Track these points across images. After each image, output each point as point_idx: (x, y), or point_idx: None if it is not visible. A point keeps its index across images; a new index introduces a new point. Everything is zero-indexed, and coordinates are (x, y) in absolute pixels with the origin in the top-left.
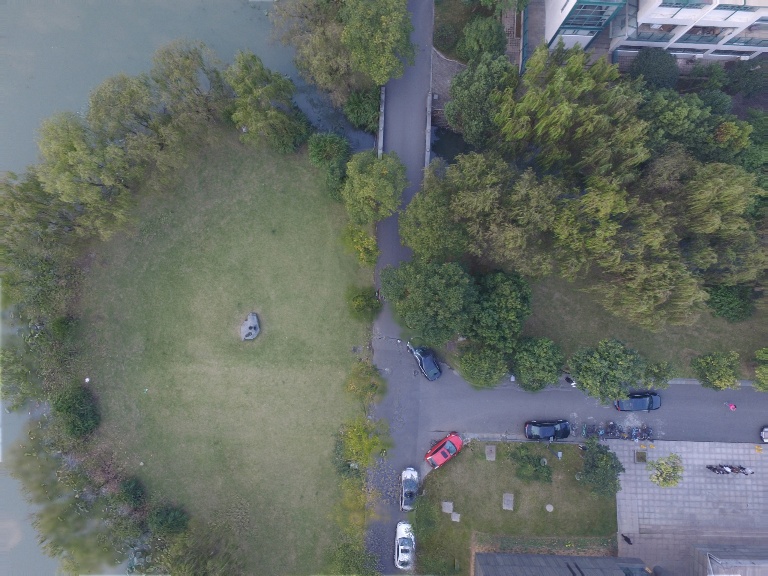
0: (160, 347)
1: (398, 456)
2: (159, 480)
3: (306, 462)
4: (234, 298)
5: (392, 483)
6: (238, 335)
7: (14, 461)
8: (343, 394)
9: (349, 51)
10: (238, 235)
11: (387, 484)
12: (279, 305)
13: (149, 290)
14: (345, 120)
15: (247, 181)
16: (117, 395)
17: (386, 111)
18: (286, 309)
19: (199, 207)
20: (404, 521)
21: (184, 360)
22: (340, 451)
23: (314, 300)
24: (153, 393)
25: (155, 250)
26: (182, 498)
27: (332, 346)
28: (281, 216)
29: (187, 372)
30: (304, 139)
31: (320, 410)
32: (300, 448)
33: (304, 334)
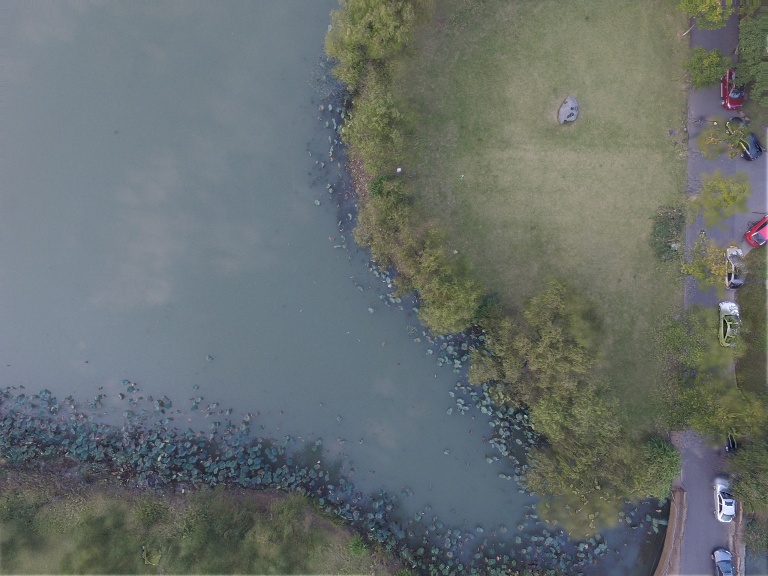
0: (475, 133)
1: (717, 237)
2: (473, 268)
3: (624, 245)
4: (549, 84)
5: (716, 261)
6: (554, 120)
7: (323, 254)
8: (660, 177)
9: None
10: (552, 22)
11: (710, 263)
12: (594, 90)
13: (462, 79)
14: None
15: None
16: (431, 183)
17: None
18: (601, 94)
19: None
20: (727, 300)
21: (500, 146)
22: (659, 233)
23: (629, 85)
24: (469, 179)
25: (466, 40)
26: (495, 286)
27: (648, 130)
28: (594, 3)
29: (503, 157)
30: None
31: (638, 193)
32: (617, 231)
33: (620, 118)
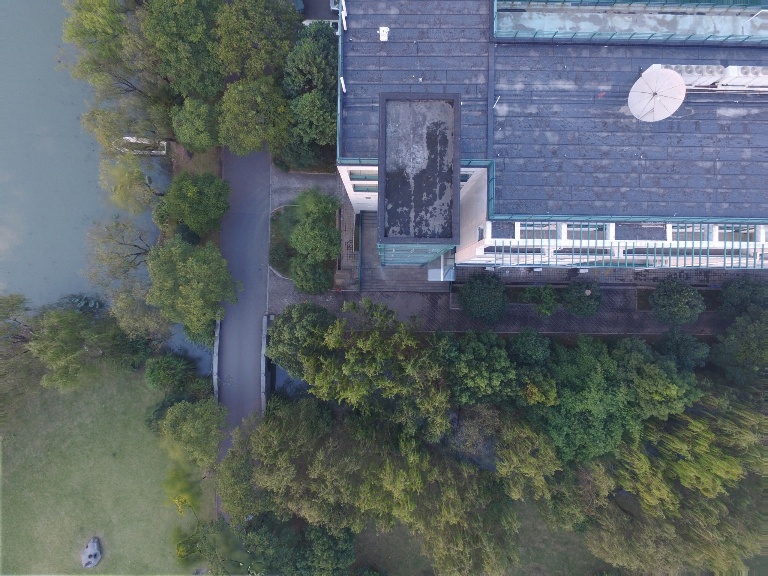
0: (4, 572)
1: None
2: None
3: None
4: (76, 522)
5: None
6: (81, 560)
7: None
8: None
9: (156, 311)
10: (79, 459)
11: None
12: (121, 529)
13: None
14: (182, 342)
15: (88, 403)
16: None
17: (221, 334)
18: (128, 533)
19: (40, 430)
20: None
21: None
22: None
23: (156, 523)
24: None
25: None
26: None
27: (175, 569)
28: (121, 439)
29: None
30: (142, 361)
31: None
32: None
33: (146, 558)
